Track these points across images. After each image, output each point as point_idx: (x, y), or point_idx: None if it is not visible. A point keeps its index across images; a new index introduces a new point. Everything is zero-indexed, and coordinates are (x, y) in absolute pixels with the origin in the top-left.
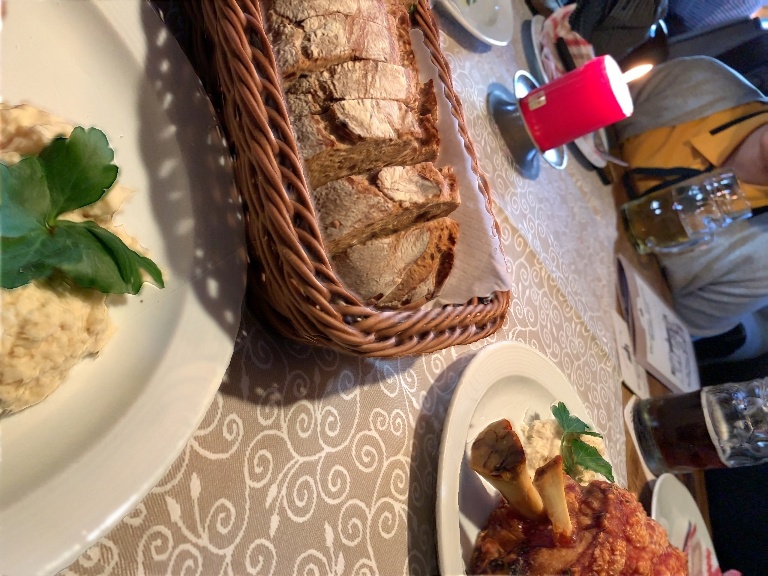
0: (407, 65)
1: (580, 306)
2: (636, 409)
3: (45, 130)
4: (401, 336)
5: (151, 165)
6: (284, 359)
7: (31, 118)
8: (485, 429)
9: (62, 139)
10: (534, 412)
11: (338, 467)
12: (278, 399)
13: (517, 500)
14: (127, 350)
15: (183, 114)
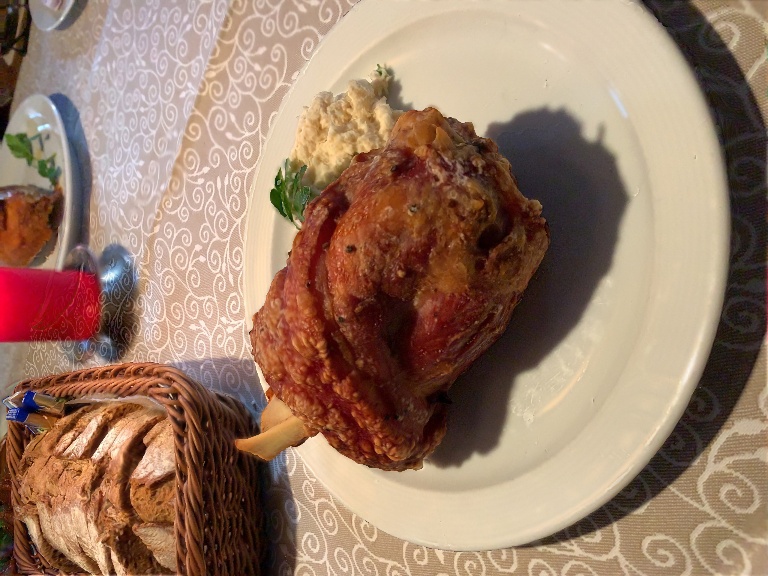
0: (79, 462)
1: None
2: None
3: None
4: None
5: None
6: None
7: None
8: None
9: None
10: None
11: (336, 554)
12: None
13: None
14: None
15: None
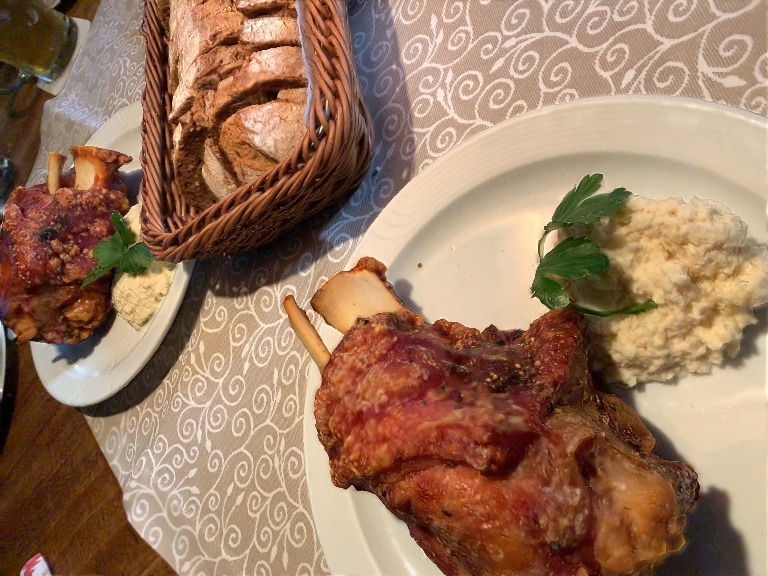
0: None
1: None
2: None
3: None
4: None
5: None
6: (255, 263)
7: None
8: None
9: None
10: None
11: (290, 329)
12: (245, 291)
13: None
14: None
15: None
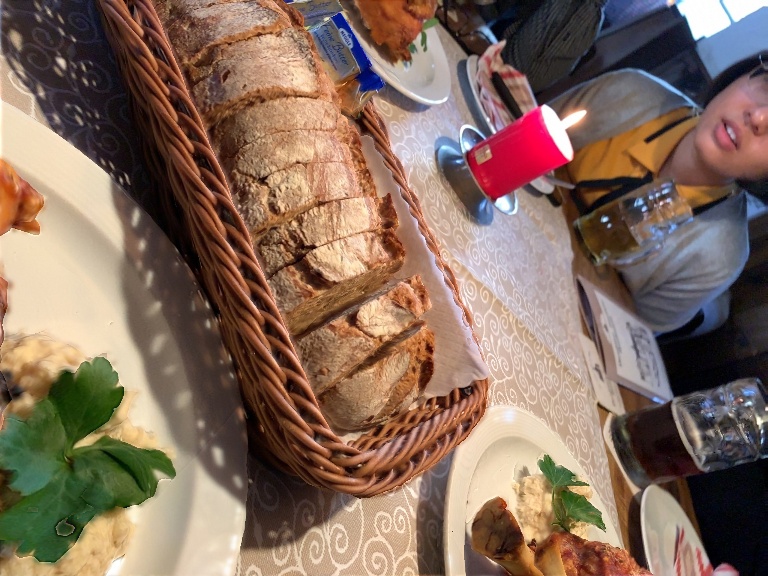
0: (364, 184)
1: (549, 339)
2: (614, 427)
3: (50, 364)
4: (398, 464)
5: (143, 344)
6: (289, 492)
7: (34, 351)
8: (482, 508)
9: (69, 375)
10: (522, 466)
11: None
12: (290, 536)
13: (521, 574)
14: (149, 542)
15: (166, 287)
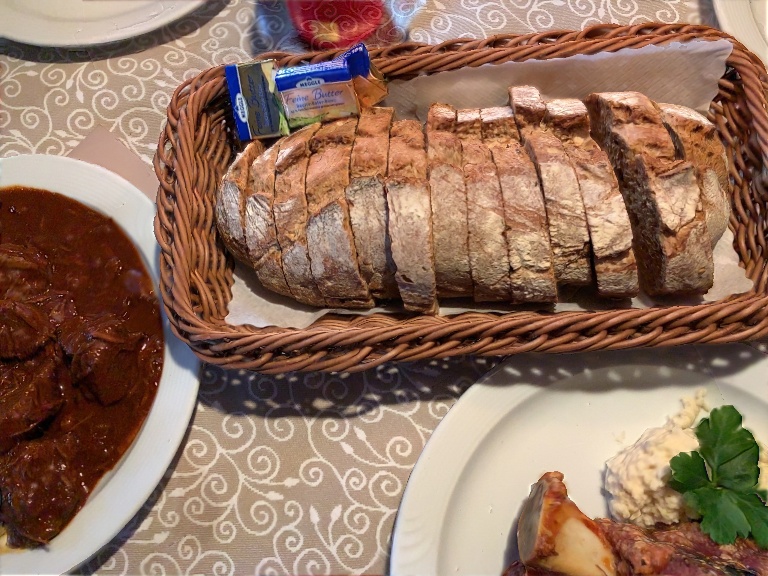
0: (498, 131)
1: None
2: None
3: (653, 483)
4: None
5: (610, 386)
6: None
7: (636, 486)
8: None
9: (673, 482)
10: None
11: None
12: None
13: None
14: (762, 427)
15: (573, 362)
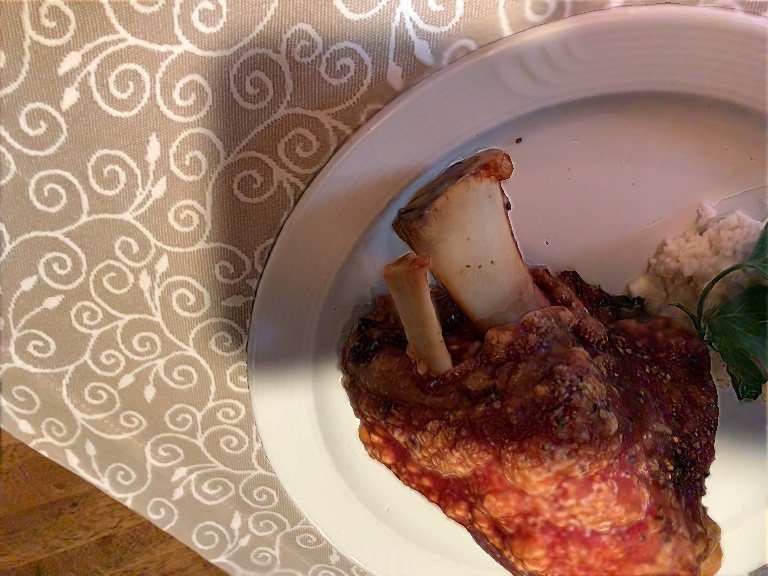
0: None
1: None
2: None
3: None
4: None
5: None
6: None
7: None
8: (480, 152)
9: None
10: None
11: (199, 78)
12: None
13: None
14: None
15: None
